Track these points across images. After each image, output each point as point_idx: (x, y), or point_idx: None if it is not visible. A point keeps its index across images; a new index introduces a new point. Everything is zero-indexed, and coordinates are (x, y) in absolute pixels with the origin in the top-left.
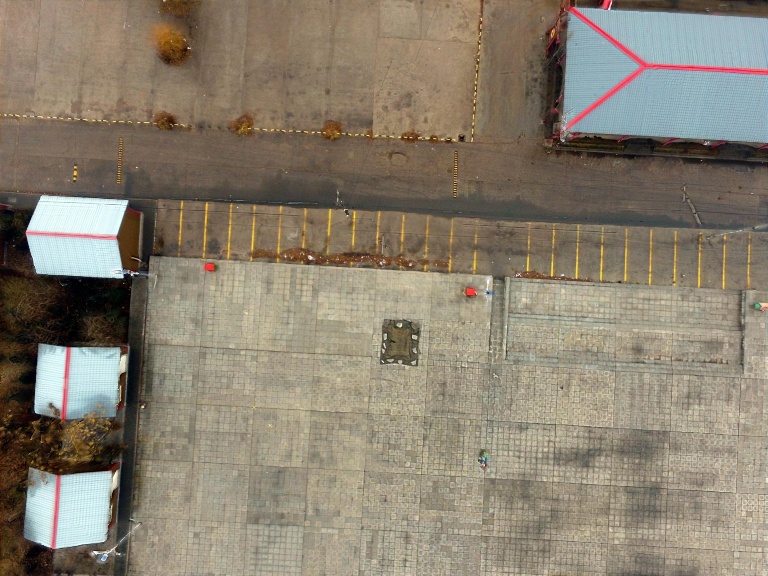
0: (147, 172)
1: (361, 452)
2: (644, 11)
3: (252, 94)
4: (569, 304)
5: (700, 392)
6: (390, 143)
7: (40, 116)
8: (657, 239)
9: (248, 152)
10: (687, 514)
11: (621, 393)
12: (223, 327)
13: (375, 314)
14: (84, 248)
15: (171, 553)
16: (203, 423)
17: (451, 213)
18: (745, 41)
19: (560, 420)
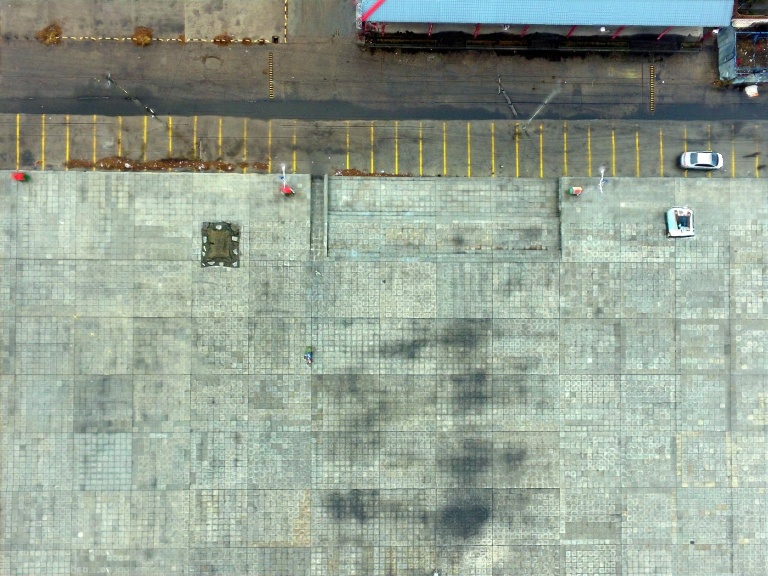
0: None
1: (186, 356)
2: None
3: (59, 3)
4: (390, 199)
5: (520, 278)
6: (203, 47)
7: None
8: (475, 132)
9: (58, 62)
10: (512, 398)
11: (443, 283)
12: (39, 238)
13: (194, 218)
14: None
15: None
16: (23, 335)
17: (269, 115)
18: None
19: (384, 313)
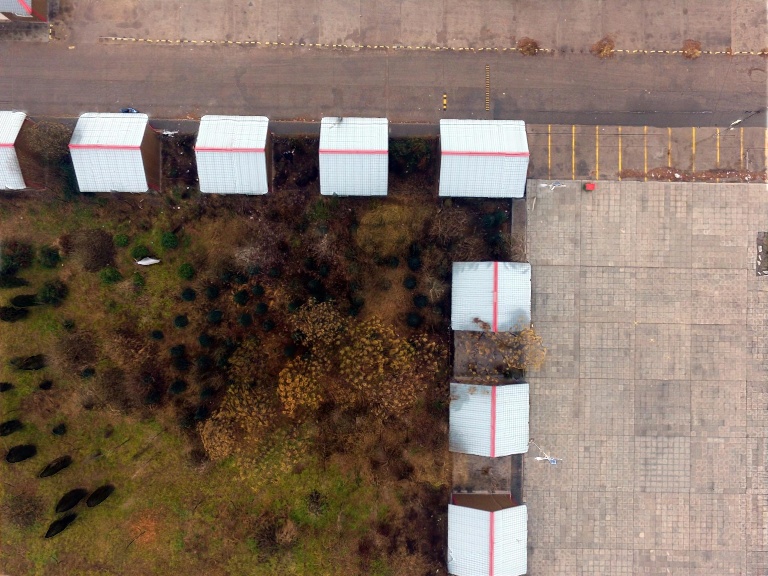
0: (514, 98)
1: (742, 362)
2: None
3: (612, 17)
4: None
5: None
6: (749, 60)
7: (410, 46)
8: None
9: (611, 74)
10: None
11: None
12: (601, 246)
13: (749, 227)
14: (494, 167)
15: (563, 467)
16: (587, 340)
17: None
18: None
19: None
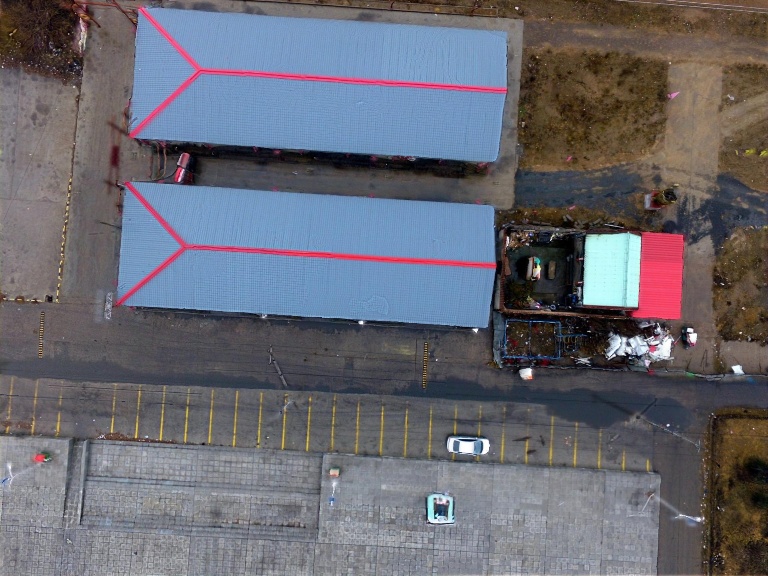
0: None
1: None
2: (233, 173)
3: None
4: (150, 467)
5: (274, 557)
6: None
7: None
8: (243, 400)
9: None
10: None
11: (195, 558)
12: None
13: None
14: None
15: None
16: None
17: (37, 374)
18: (293, 219)
19: None
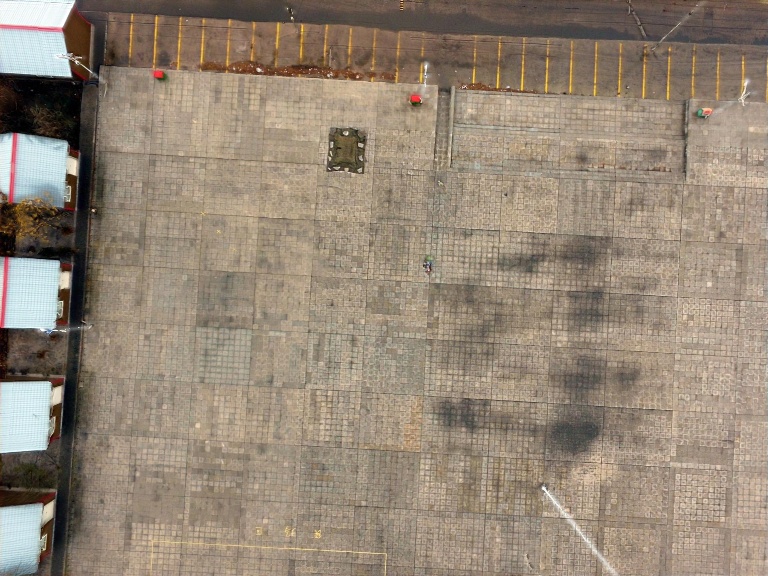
0: None
1: (308, 257)
2: None
3: None
4: (514, 114)
5: (643, 198)
6: None
7: None
8: (602, 51)
9: None
10: (629, 318)
11: (564, 200)
12: (172, 135)
13: (322, 122)
14: (31, 42)
15: (122, 355)
16: (153, 229)
17: (398, 27)
18: None
19: (504, 226)
